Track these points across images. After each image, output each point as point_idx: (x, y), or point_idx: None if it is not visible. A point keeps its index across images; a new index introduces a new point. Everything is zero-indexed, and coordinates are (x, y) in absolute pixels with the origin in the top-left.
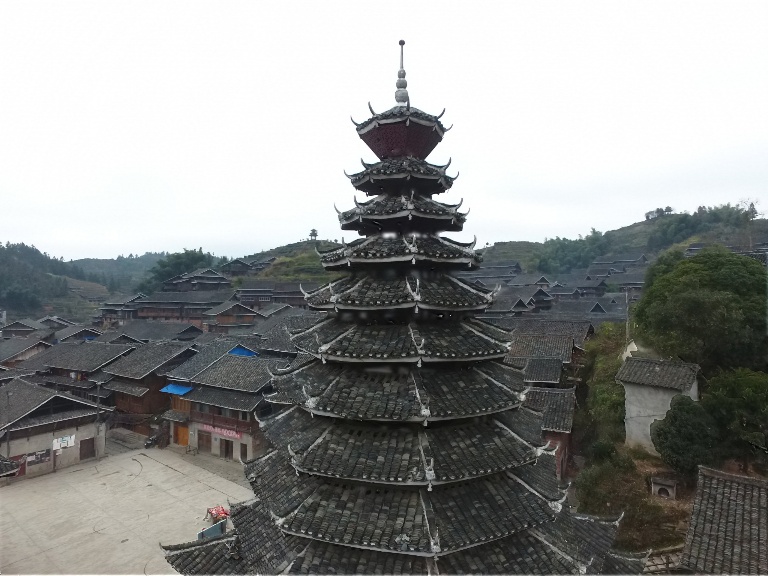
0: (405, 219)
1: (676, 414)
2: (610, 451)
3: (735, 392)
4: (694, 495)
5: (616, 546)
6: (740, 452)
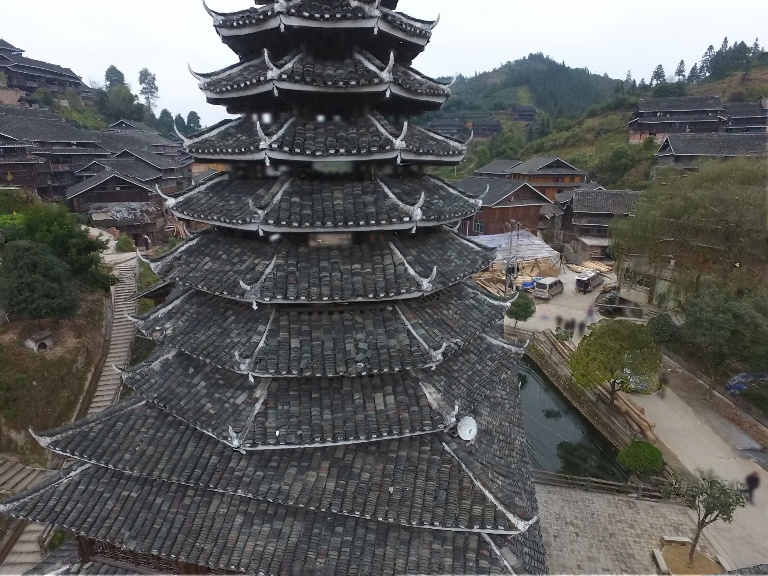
0: (392, 5)
1: (35, 260)
2: None
3: (49, 226)
4: (56, 336)
5: (60, 416)
6: (84, 275)
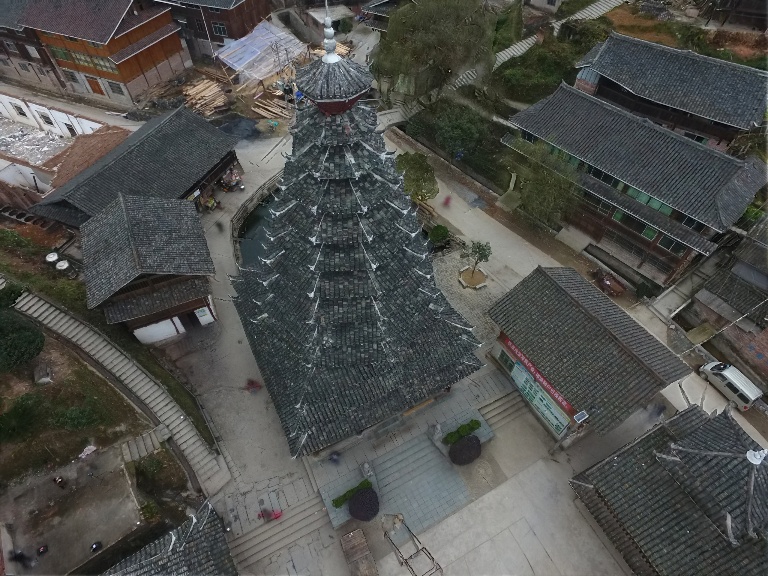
0: None
1: None
2: (22, 409)
3: None
4: (35, 362)
5: None
6: None
